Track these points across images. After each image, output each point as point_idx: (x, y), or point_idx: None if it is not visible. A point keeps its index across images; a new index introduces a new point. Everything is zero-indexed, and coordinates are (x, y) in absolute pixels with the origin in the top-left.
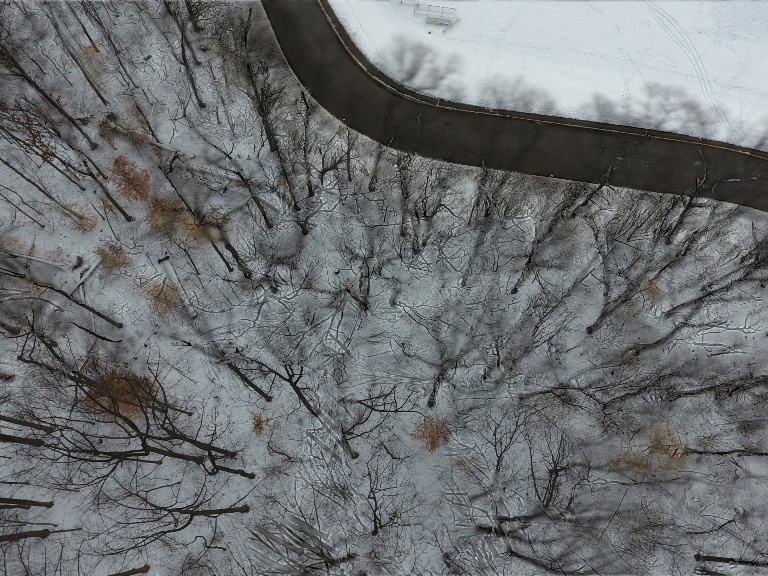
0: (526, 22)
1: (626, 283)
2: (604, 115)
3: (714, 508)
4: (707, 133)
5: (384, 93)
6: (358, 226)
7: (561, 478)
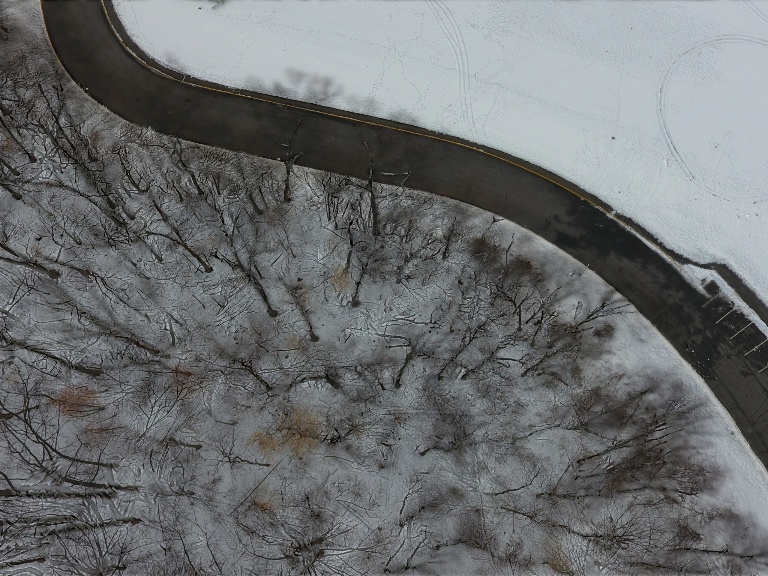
0: (300, 4)
1: (323, 270)
2: (346, 102)
3: (348, 494)
4: (445, 128)
5: (134, 65)
6: (72, 195)
7: (169, 452)
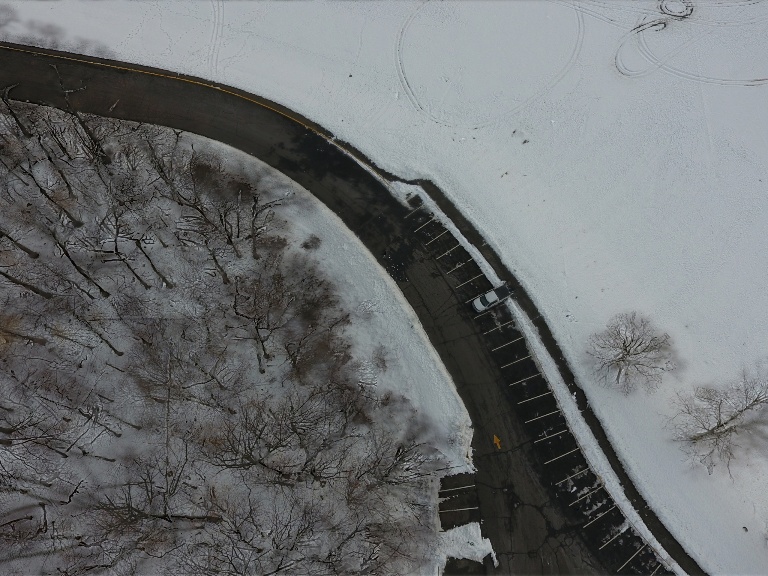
0: None
1: None
2: (97, 50)
3: (41, 389)
4: (187, 69)
5: None
6: None
7: None
